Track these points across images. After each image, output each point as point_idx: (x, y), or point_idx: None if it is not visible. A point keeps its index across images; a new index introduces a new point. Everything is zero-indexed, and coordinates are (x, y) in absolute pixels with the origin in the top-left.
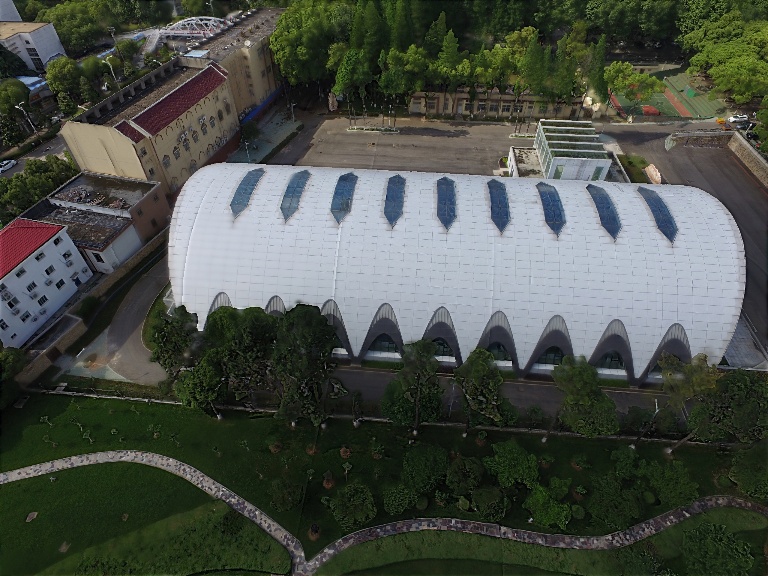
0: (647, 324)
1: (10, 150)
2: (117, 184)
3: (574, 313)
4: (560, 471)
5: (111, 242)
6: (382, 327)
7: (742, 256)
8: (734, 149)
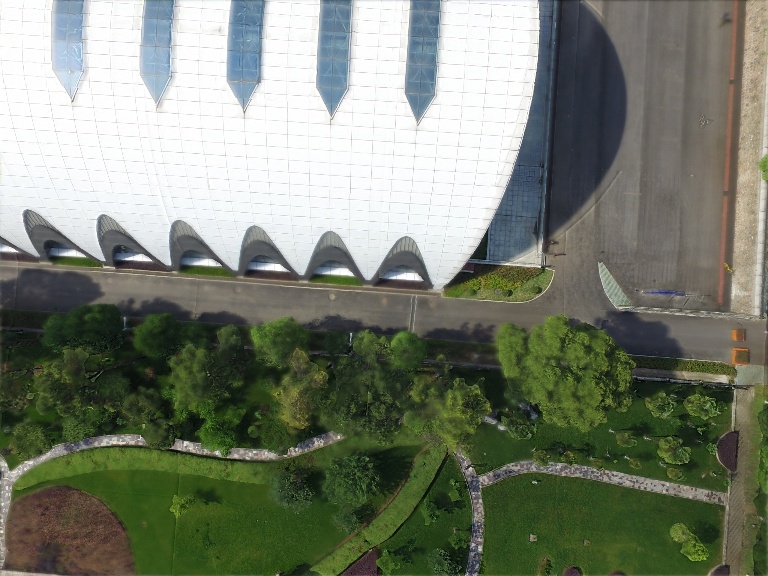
0: (369, 237)
1: None
2: None
3: (275, 224)
4: (252, 389)
5: None
6: (42, 234)
7: (516, 146)
8: None
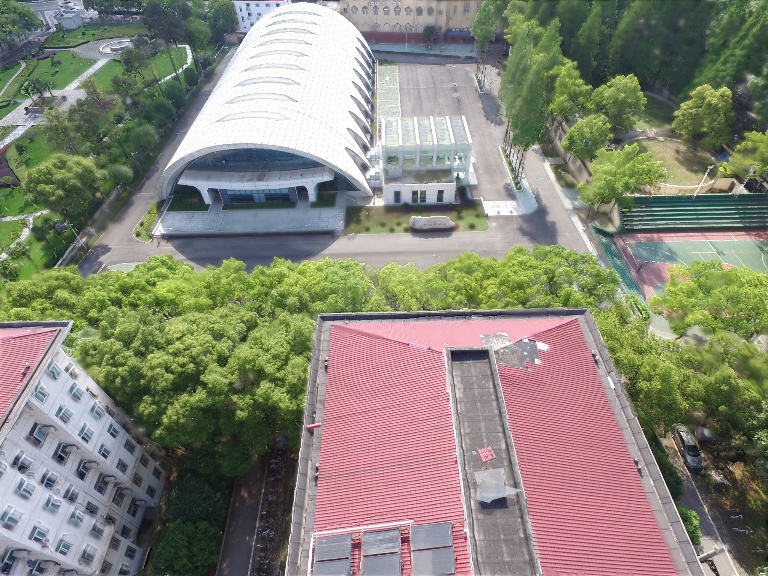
0: None
1: None
2: (334, 8)
3: None
4: None
5: None
6: None
7: None
8: None
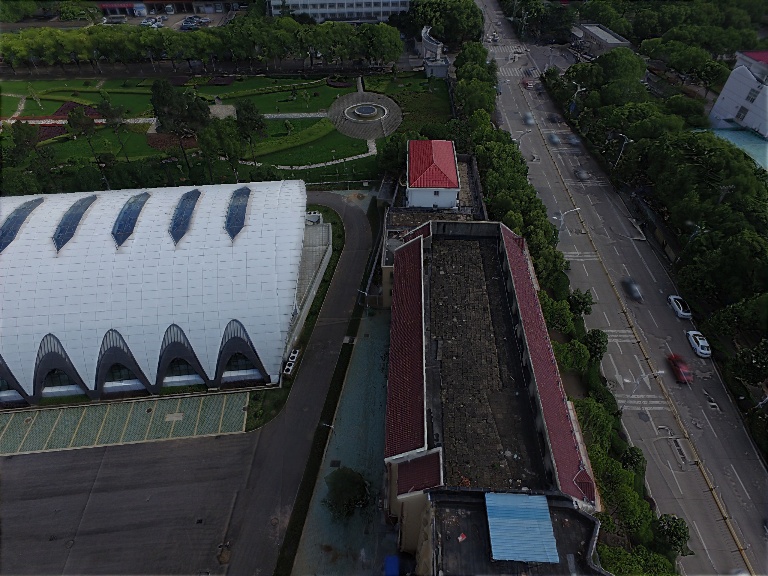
0: None
1: (767, 388)
2: None
3: None
4: (62, 183)
5: (385, 217)
6: None
7: None
8: None
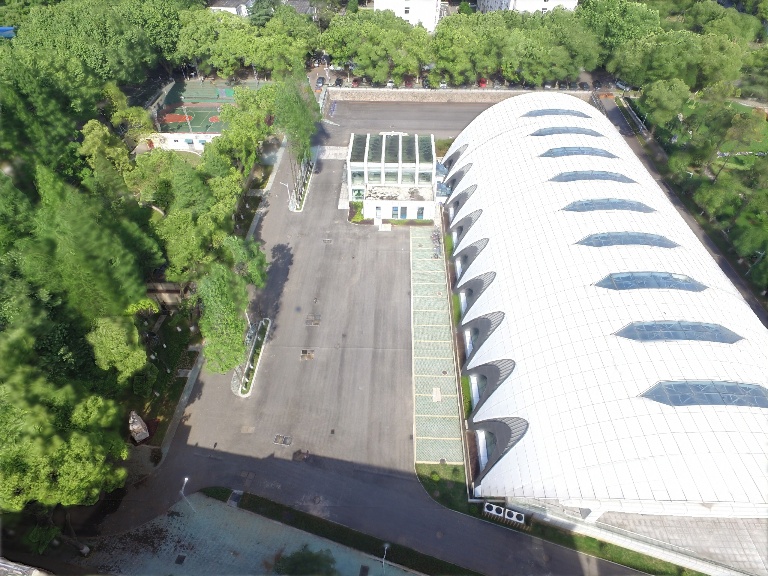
0: None
1: None
2: None
3: None
4: None
5: None
6: None
7: None
8: (342, 98)
